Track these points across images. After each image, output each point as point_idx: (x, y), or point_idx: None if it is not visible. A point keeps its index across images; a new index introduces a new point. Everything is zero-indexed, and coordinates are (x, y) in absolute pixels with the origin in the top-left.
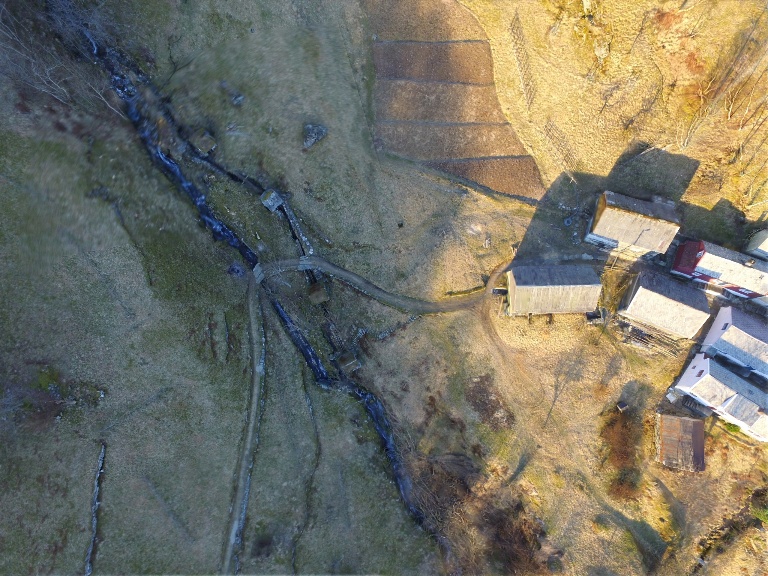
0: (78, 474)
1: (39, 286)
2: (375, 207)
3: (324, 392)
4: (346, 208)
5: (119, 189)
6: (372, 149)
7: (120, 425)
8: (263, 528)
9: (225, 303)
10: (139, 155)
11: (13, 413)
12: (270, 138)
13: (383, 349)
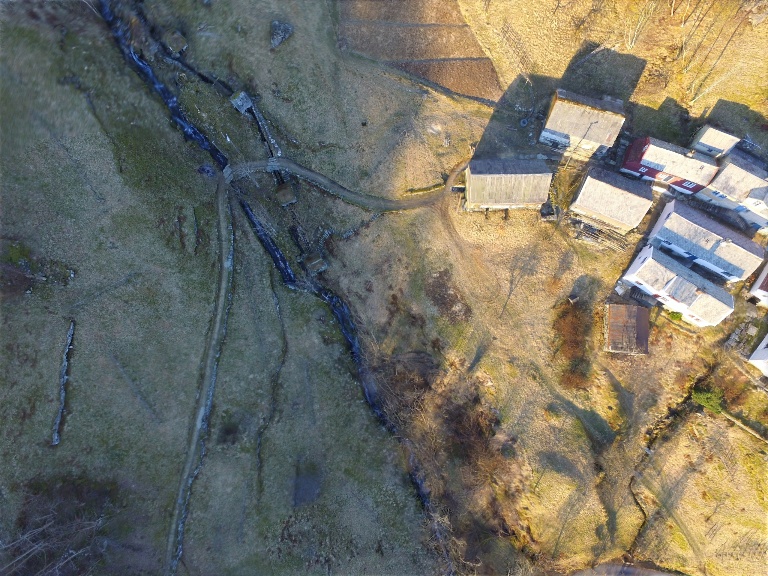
0: (47, 347)
1: (11, 166)
2: (340, 106)
3: (291, 292)
4: (312, 108)
5: (91, 80)
6: (337, 48)
7: (89, 305)
8: (229, 417)
9: (195, 199)
10: (112, 52)
11: None
12: (239, 38)
13: (348, 248)
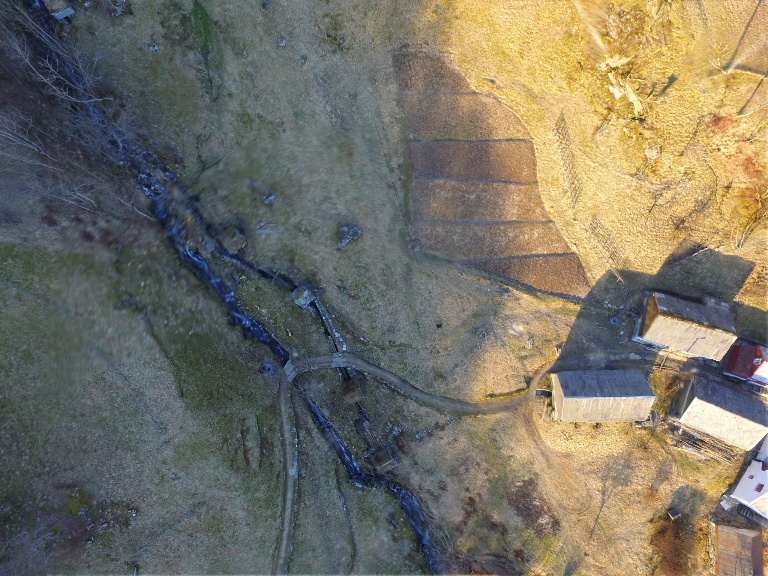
0: None
1: (68, 404)
2: (412, 307)
3: (358, 490)
4: (382, 307)
5: (148, 296)
6: (409, 249)
7: (152, 545)
8: None
9: (257, 405)
10: (167, 256)
11: (43, 543)
12: (302, 237)
13: (420, 449)
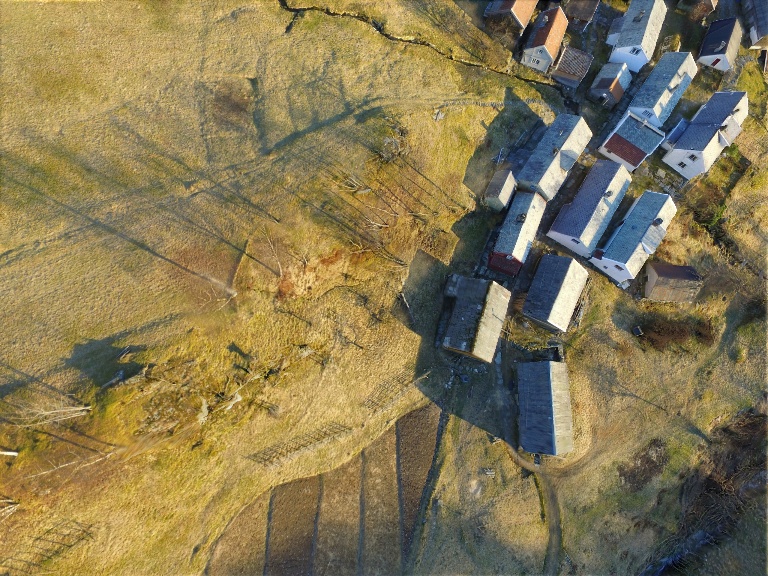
0: None
1: None
2: None
3: None
4: None
5: None
6: None
7: None
8: None
9: None
10: None
11: None
12: None
13: None
